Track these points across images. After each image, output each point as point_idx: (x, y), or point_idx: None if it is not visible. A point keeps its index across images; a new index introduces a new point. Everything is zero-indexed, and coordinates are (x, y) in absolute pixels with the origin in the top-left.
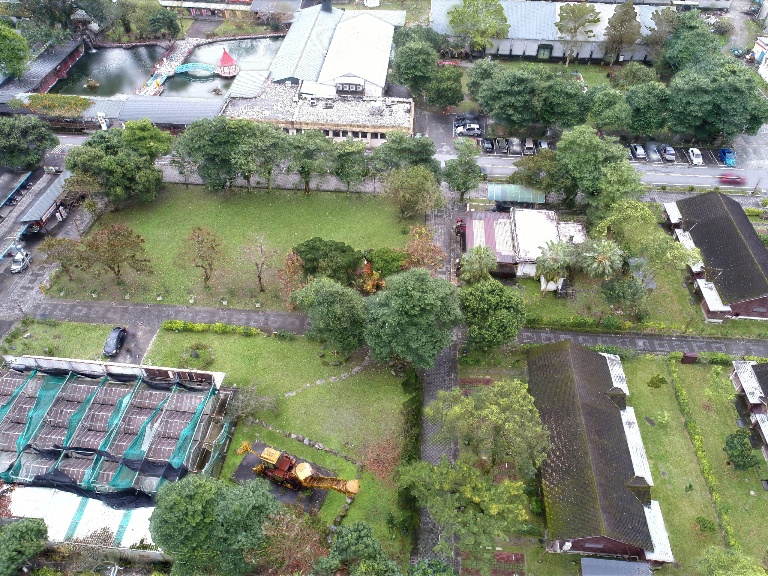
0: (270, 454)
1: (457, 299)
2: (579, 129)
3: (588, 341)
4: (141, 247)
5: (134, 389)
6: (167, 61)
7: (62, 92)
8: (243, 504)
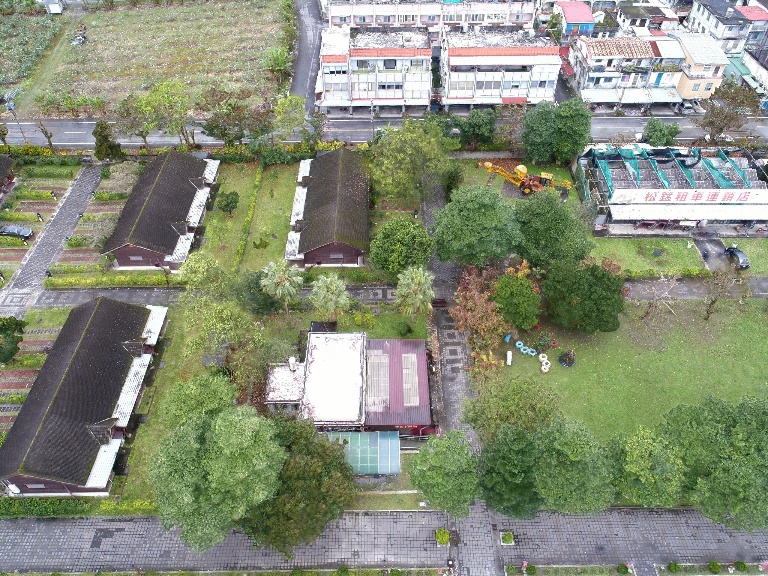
0: (547, 175)
1: (437, 235)
2: (251, 422)
3: (301, 295)
4: None
5: (666, 187)
6: None
7: None
8: (541, 103)
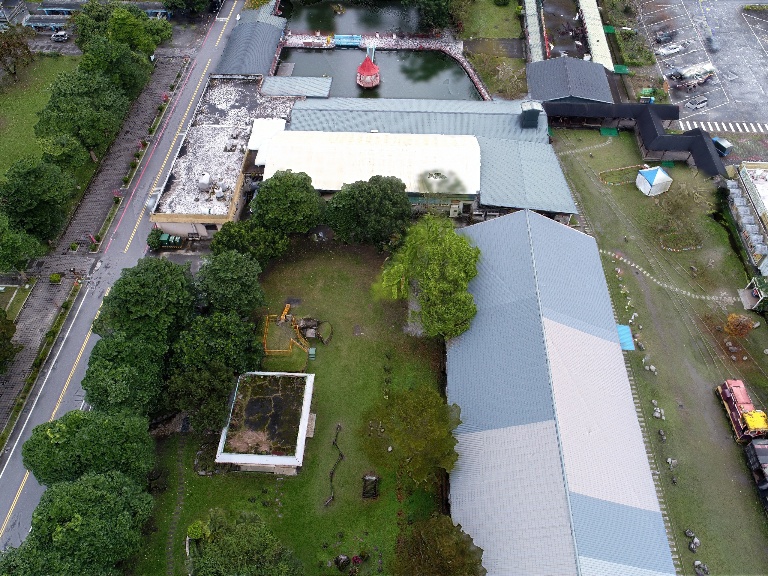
0: None
1: None
2: None
3: None
4: (0, 66)
5: None
6: (395, 39)
7: (330, 1)
8: None
